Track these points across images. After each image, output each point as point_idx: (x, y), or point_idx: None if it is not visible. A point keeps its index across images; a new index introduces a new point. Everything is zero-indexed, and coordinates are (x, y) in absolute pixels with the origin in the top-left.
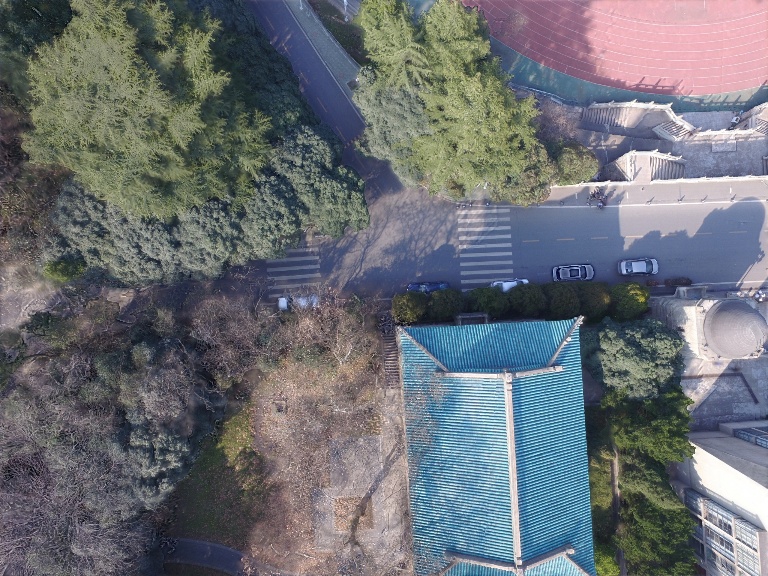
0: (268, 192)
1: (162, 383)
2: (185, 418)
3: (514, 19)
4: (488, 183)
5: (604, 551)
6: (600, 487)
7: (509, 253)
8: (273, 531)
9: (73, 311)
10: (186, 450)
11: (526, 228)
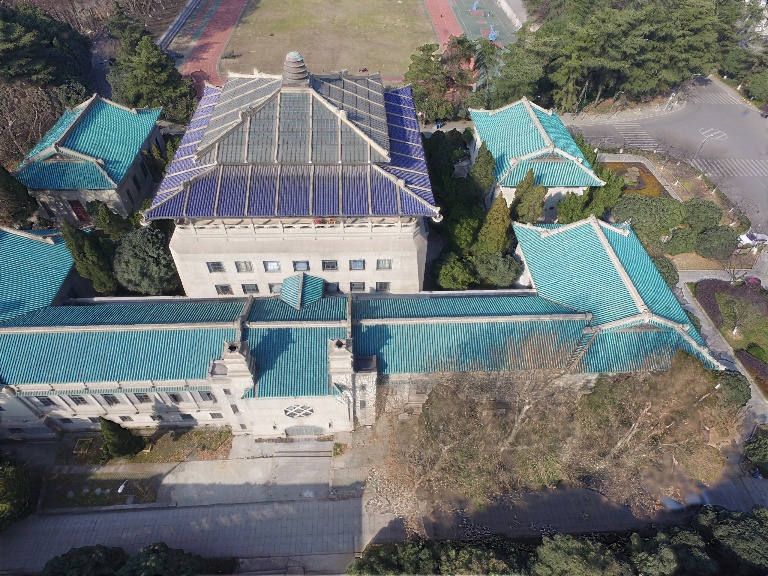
0: (41, 89)
1: None
2: None
3: (200, 71)
4: None
5: None
6: None
7: None
8: None
9: None
10: None
11: None
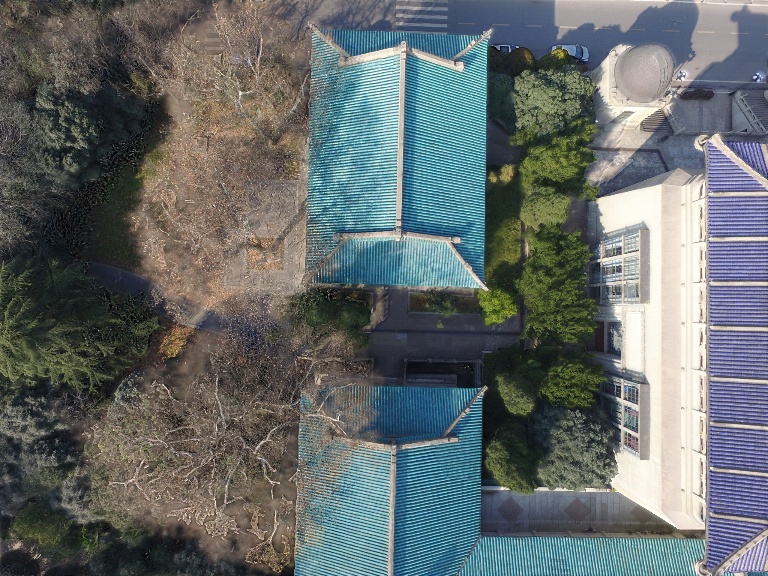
0: None
1: (74, 59)
2: (97, 106)
3: None
4: None
5: (504, 291)
6: (509, 243)
7: (444, 33)
8: (185, 263)
9: (2, 15)
10: (94, 133)
11: (463, 11)
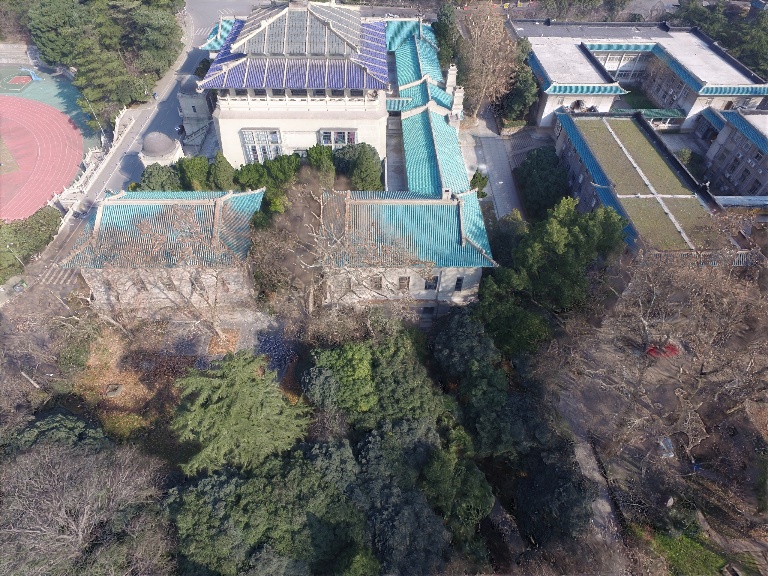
0: None
1: None
2: None
3: None
4: (19, 252)
5: None
6: None
7: None
8: None
9: None
10: None
11: None
